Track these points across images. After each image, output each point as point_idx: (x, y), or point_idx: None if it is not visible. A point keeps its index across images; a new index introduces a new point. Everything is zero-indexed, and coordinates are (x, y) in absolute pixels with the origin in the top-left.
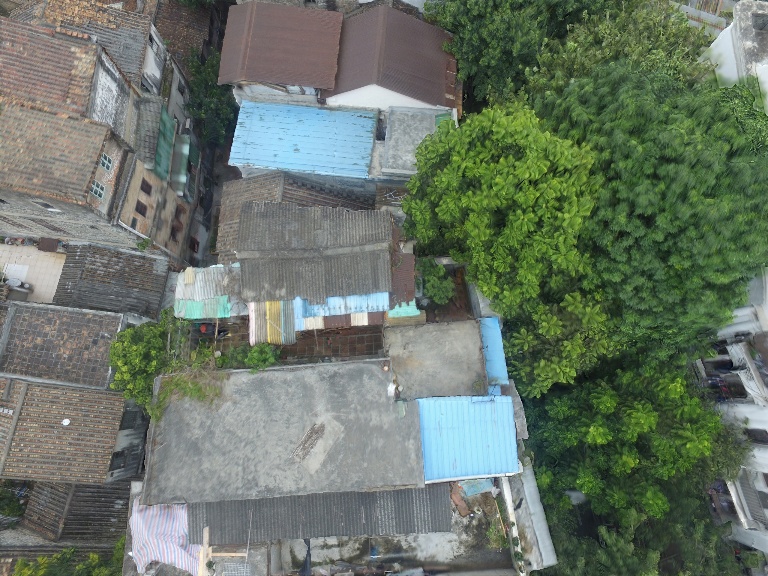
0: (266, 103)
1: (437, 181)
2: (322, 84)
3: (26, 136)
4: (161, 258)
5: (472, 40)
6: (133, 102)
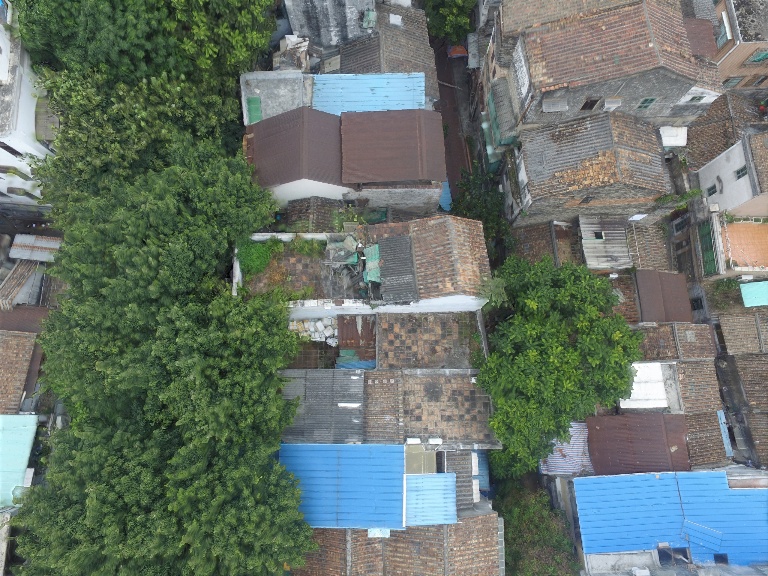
0: None
1: None
2: (351, 115)
3: (555, 1)
4: None
5: None
6: None
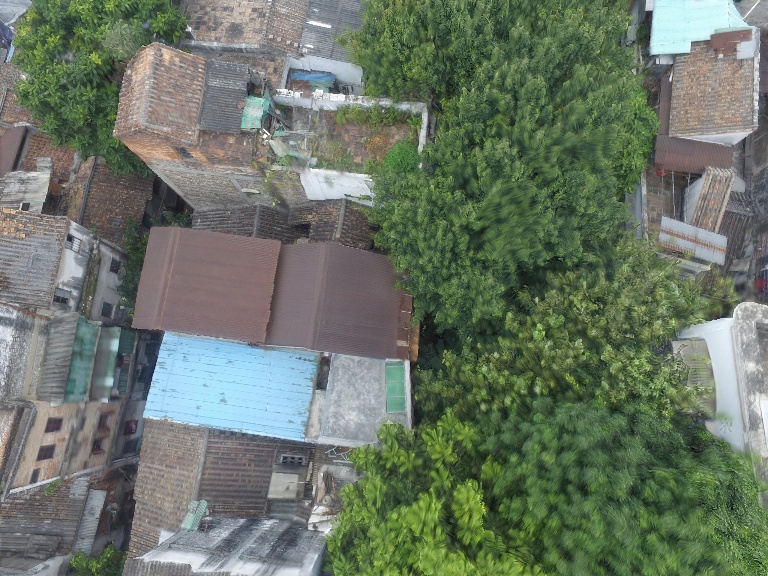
0: (191, 338)
1: (358, 570)
2: (251, 337)
3: None
4: (80, 478)
5: (428, 286)
6: (39, 331)
